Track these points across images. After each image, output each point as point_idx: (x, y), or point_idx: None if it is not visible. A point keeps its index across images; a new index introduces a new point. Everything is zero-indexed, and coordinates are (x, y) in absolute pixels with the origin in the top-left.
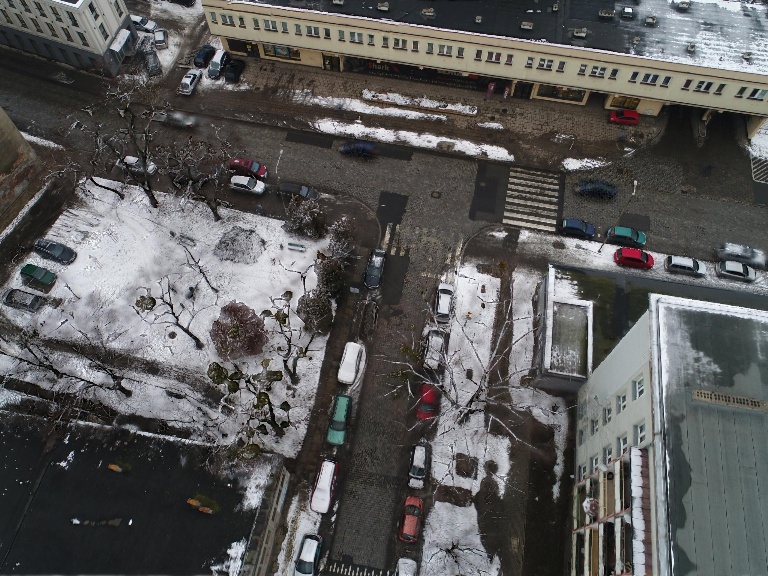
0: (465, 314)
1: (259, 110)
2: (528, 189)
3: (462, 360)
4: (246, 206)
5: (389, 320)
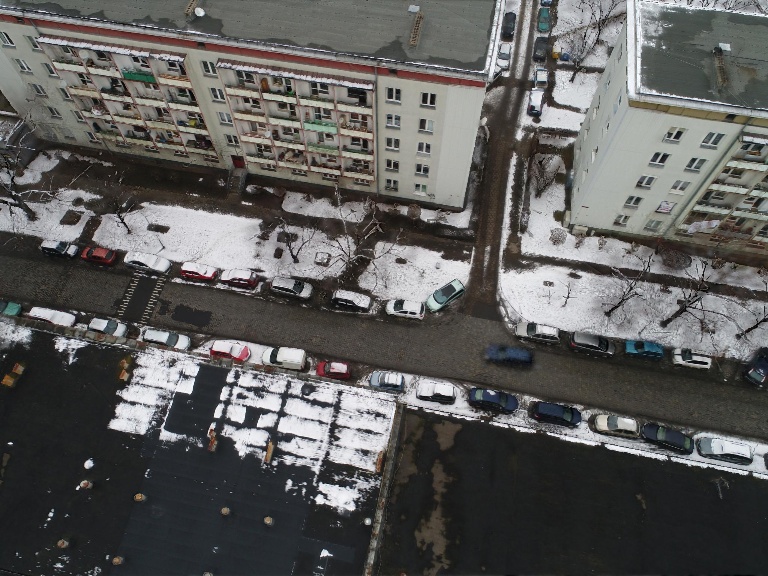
0: None
1: None
2: None
3: None
4: None
5: None
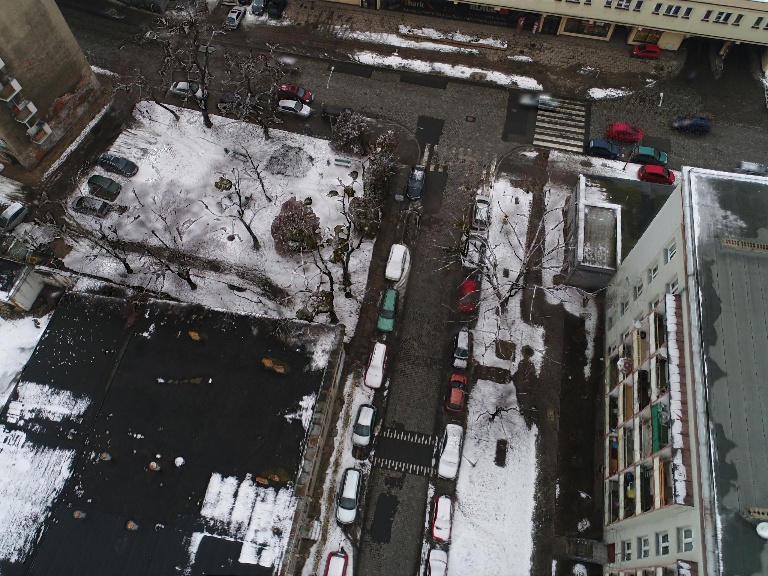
0: (500, 222)
1: (301, 43)
2: (556, 115)
3: (499, 261)
4: (293, 128)
5: (430, 227)
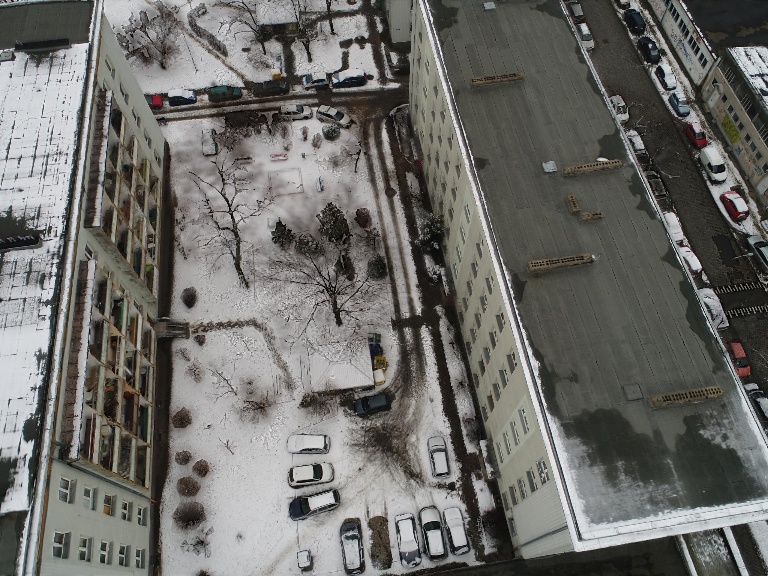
0: None
1: None
2: None
3: None
4: None
5: None
